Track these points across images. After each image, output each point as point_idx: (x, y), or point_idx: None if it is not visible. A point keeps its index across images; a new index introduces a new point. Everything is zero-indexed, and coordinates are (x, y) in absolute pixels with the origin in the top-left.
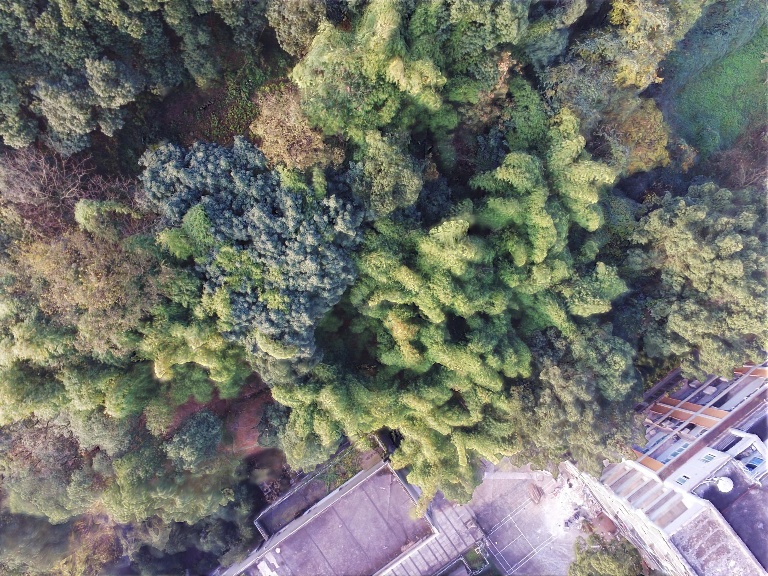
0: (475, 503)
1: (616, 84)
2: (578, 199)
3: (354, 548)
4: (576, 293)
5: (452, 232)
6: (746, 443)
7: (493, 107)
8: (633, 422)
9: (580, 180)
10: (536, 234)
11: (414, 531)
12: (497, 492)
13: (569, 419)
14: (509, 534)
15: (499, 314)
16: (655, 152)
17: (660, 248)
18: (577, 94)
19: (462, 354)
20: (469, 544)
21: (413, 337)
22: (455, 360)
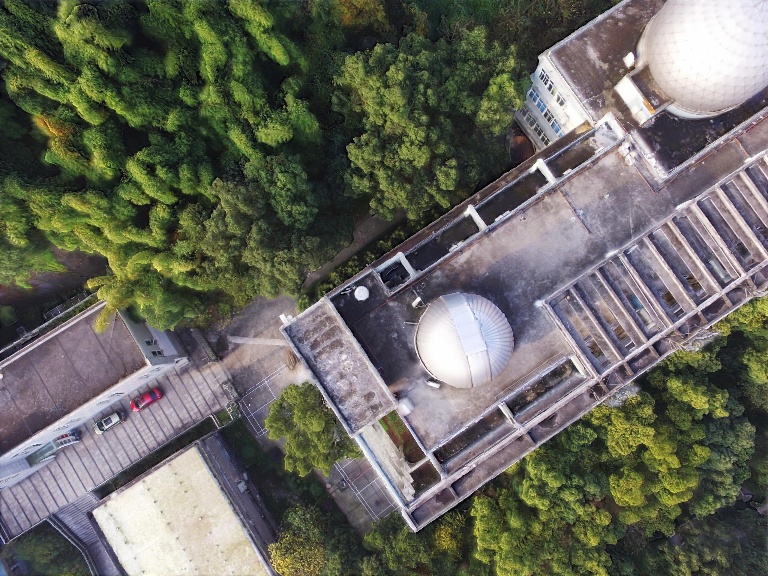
0: (233, 366)
1: None
2: (250, 21)
3: (74, 378)
4: (262, 121)
5: (76, 14)
6: (391, 259)
7: None
8: (304, 245)
9: None
10: (207, 51)
11: (133, 365)
12: (255, 357)
13: (229, 230)
14: (262, 397)
15: (180, 133)
16: None
17: (351, 86)
18: None
19: (130, 162)
20: (223, 404)
21: (75, 137)
22: (106, 157)
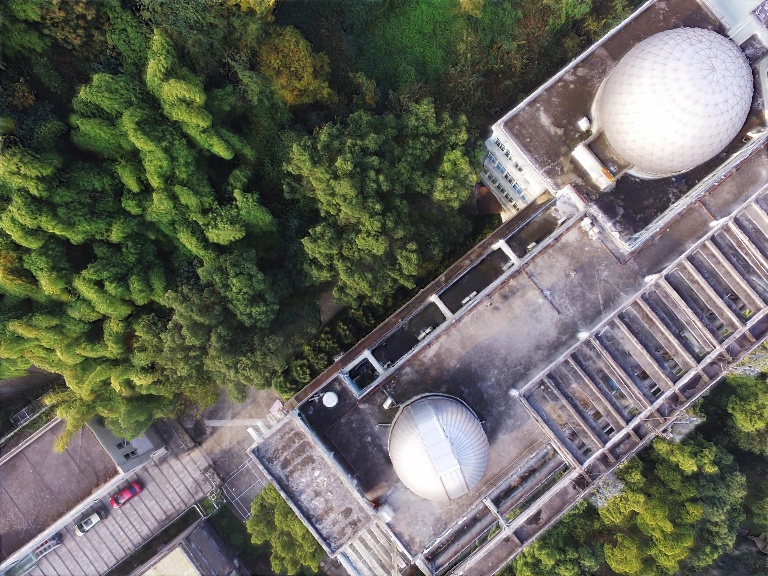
0: (212, 451)
1: (232, 8)
2: (188, 122)
3: (45, 492)
4: (212, 221)
5: None
6: (357, 359)
7: (93, 31)
8: (268, 346)
9: (170, 100)
10: (145, 158)
11: (105, 473)
12: (234, 439)
13: (186, 343)
14: (246, 480)
15: (127, 243)
16: (302, 80)
17: None
18: (175, 15)
19: (76, 281)
20: (206, 491)
21: (14, 264)
22: (48, 284)
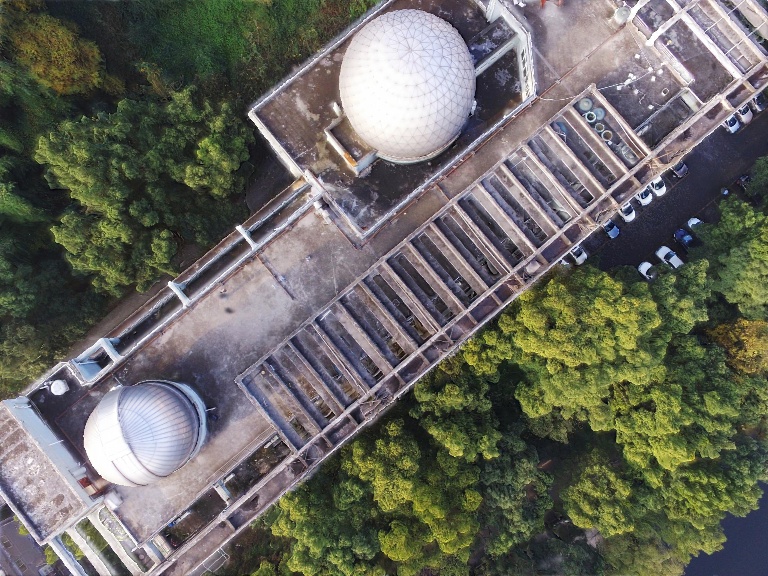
0: None
1: None
2: None
3: None
4: None
5: None
6: None
7: None
8: None
9: None
10: None
11: None
12: None
13: None
14: None
15: None
16: (63, 70)
17: None
18: None
19: None
20: None
21: None
22: None
